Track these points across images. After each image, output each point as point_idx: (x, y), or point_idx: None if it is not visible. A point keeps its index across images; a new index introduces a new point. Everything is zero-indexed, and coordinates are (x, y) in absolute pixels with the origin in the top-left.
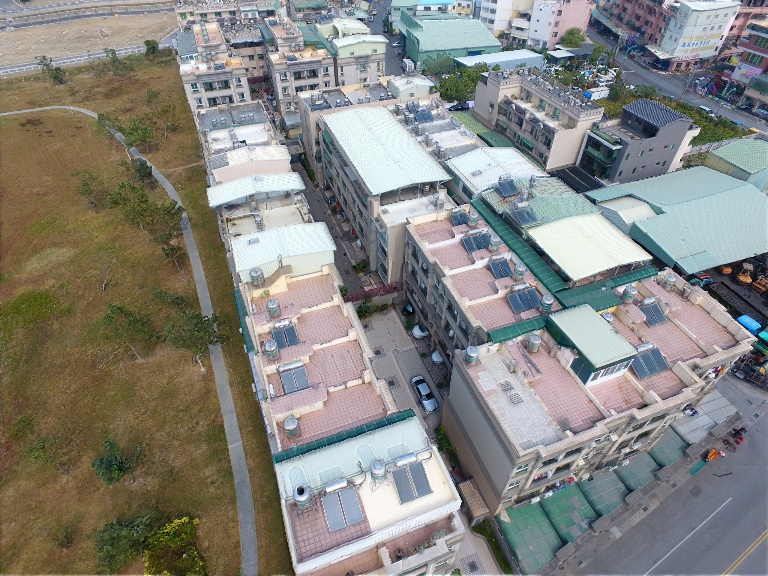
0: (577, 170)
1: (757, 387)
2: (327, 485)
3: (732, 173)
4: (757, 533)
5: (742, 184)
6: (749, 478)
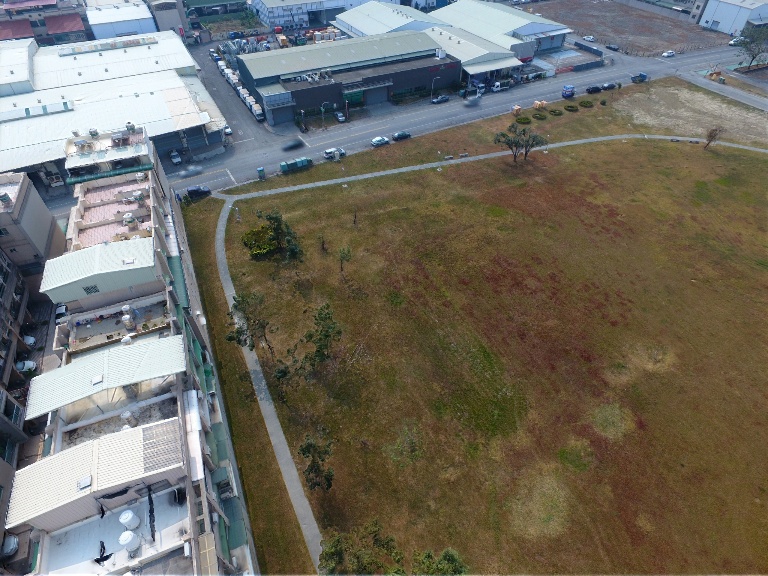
0: None
1: None
2: (120, 134)
3: None
4: None
5: None
6: None
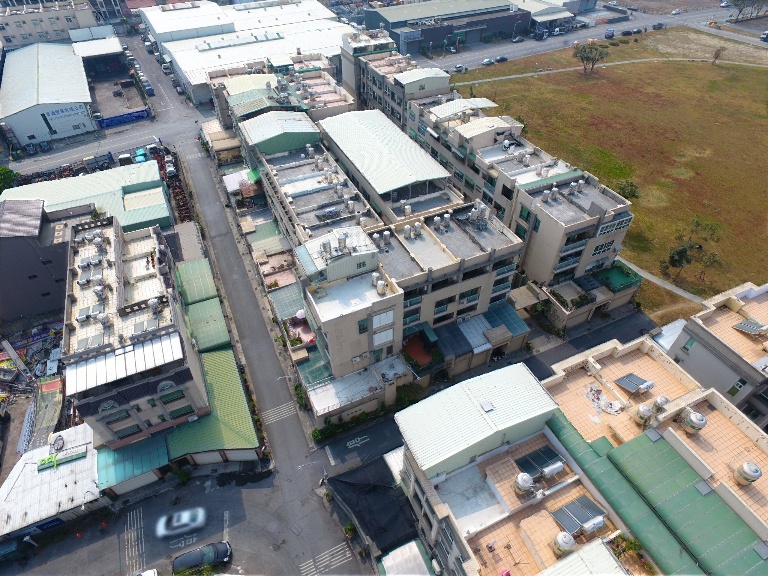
0: None
1: None
2: None
3: None
4: None
5: None
6: None
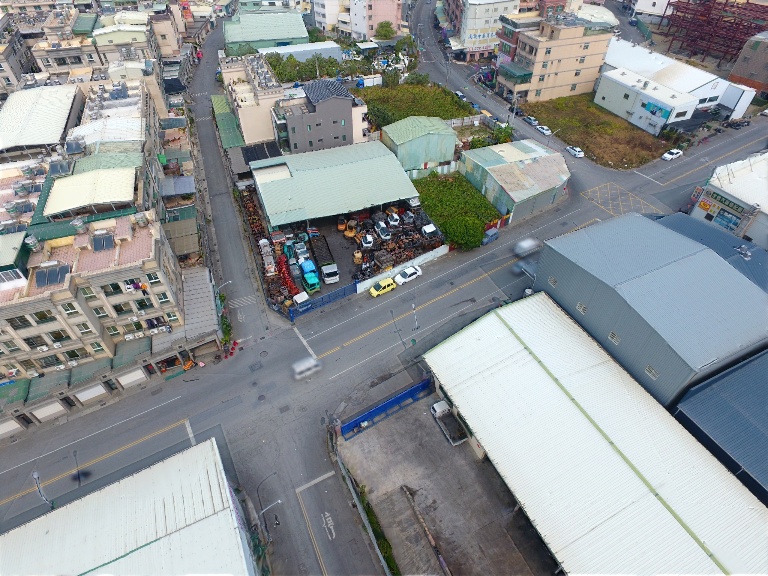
0: (273, 144)
1: (284, 317)
2: None
3: (392, 145)
4: (177, 421)
5: (386, 154)
6: (209, 382)
